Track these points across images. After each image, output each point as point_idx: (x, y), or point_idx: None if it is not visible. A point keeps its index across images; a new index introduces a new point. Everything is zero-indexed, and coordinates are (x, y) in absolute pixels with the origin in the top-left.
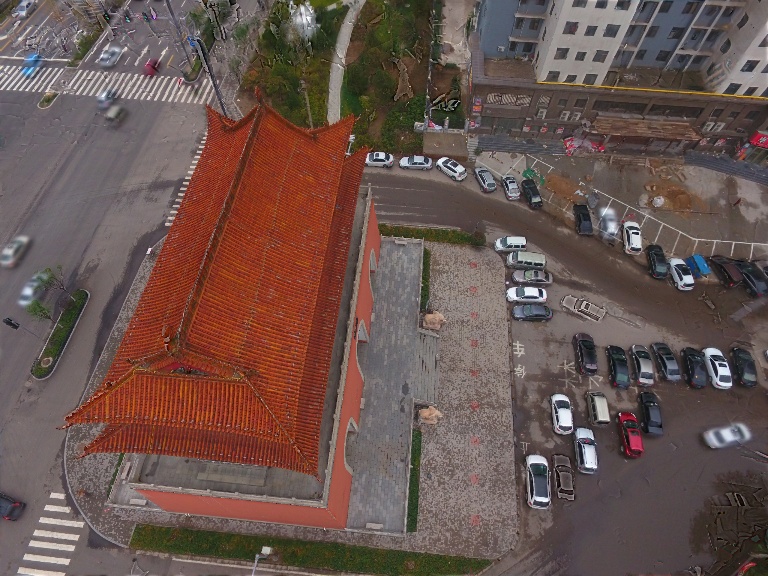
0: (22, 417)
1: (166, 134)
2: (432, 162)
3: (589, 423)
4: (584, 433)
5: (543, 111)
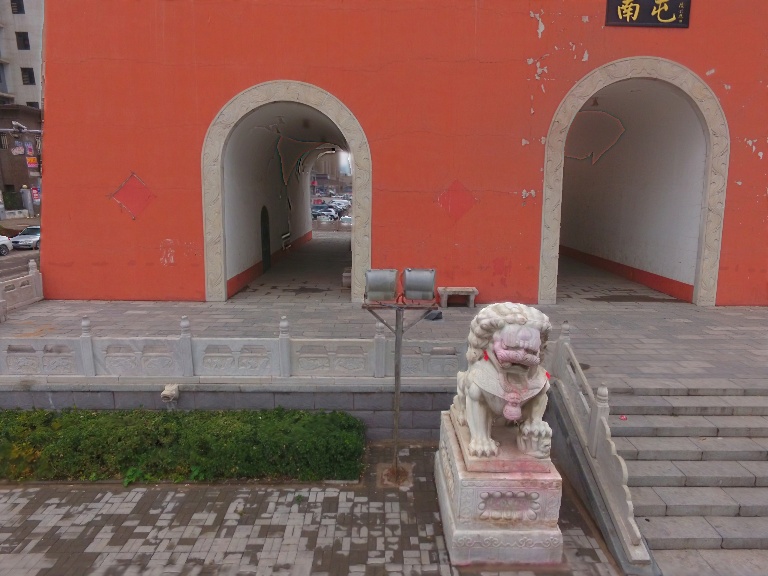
0: None
1: None
2: None
3: None
4: None
5: None
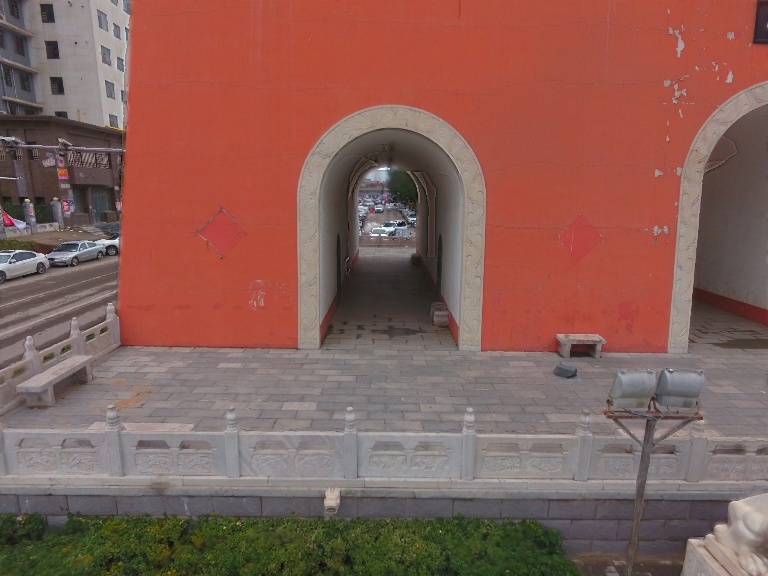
0: None
1: None
2: None
3: None
4: None
5: None
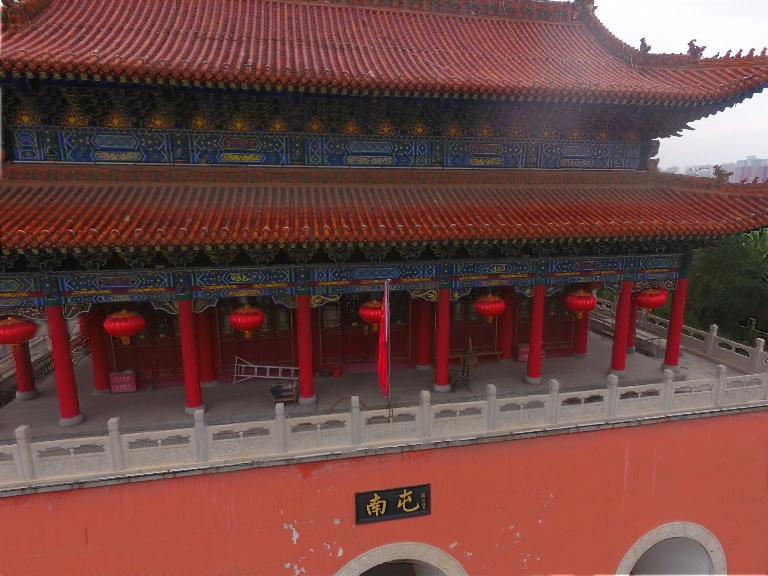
0: None
1: None
2: None
3: None
4: None
5: None
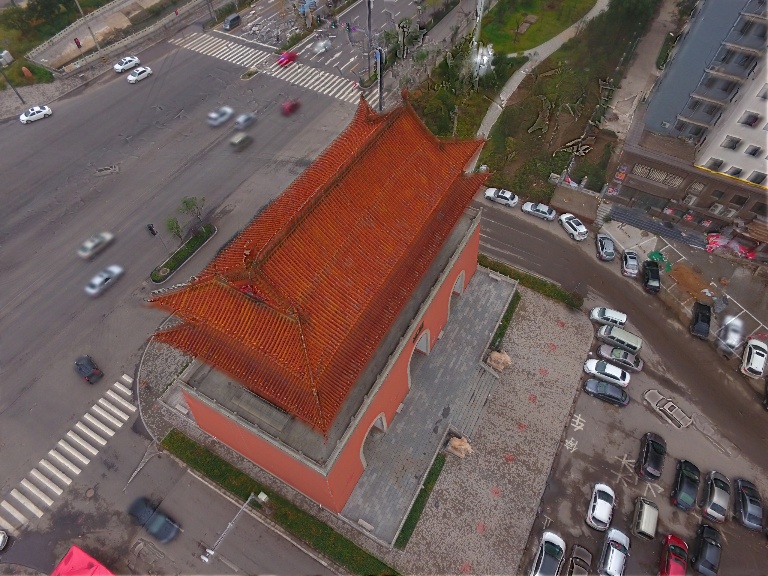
0: (130, 307)
1: (327, 124)
2: (555, 215)
3: (629, 530)
4: (619, 537)
5: (692, 197)
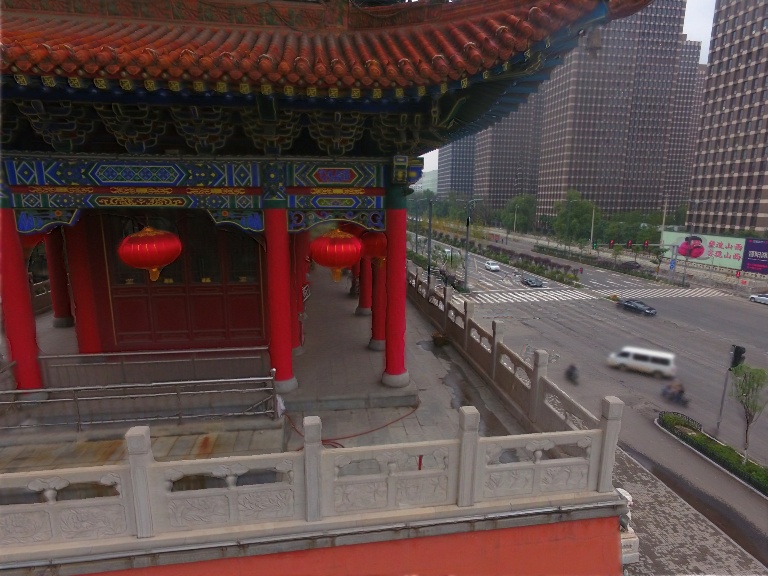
0: (623, 395)
1: None
2: None
3: None
4: None
5: None
